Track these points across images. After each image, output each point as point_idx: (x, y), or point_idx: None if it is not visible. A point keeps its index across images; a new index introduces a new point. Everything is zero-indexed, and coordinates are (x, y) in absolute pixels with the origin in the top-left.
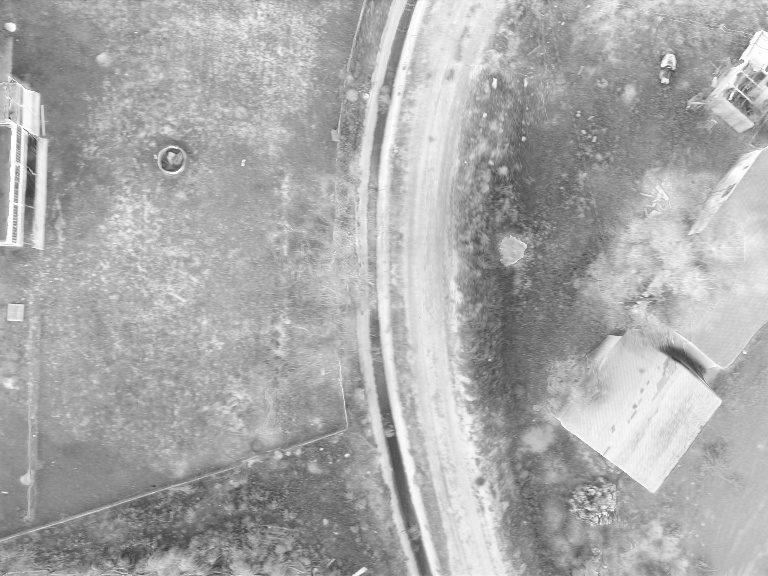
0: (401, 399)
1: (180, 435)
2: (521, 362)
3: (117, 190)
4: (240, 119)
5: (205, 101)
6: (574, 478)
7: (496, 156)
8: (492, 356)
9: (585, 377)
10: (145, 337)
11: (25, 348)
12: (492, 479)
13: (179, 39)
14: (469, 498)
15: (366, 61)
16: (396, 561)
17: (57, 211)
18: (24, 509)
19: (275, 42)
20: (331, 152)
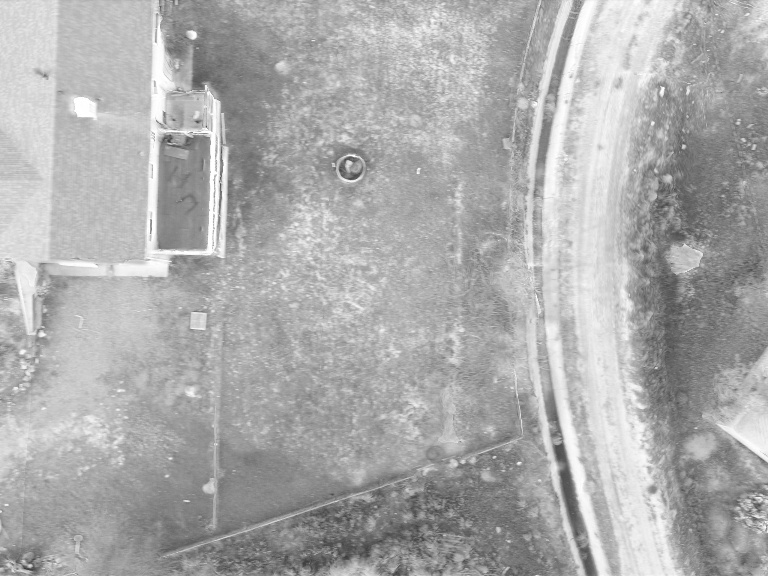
0: (571, 407)
1: (358, 443)
2: (682, 370)
3: (296, 198)
4: (415, 127)
5: (381, 109)
6: (737, 486)
7: (660, 164)
8: (659, 364)
9: (763, 386)
10: (324, 345)
11: (207, 356)
12: (662, 487)
13: (355, 47)
14: (640, 506)
15: (534, 69)
16: (568, 569)
17: (238, 219)
18: (206, 518)
19: (448, 50)
20: (502, 160)
